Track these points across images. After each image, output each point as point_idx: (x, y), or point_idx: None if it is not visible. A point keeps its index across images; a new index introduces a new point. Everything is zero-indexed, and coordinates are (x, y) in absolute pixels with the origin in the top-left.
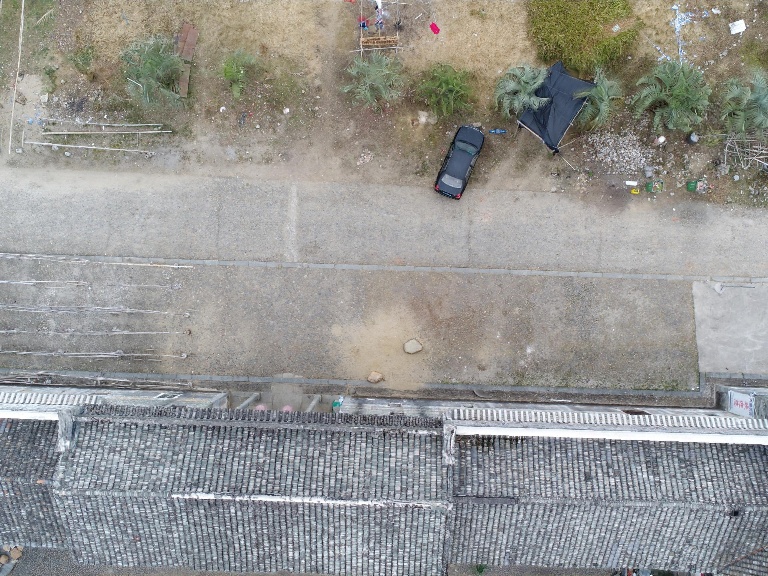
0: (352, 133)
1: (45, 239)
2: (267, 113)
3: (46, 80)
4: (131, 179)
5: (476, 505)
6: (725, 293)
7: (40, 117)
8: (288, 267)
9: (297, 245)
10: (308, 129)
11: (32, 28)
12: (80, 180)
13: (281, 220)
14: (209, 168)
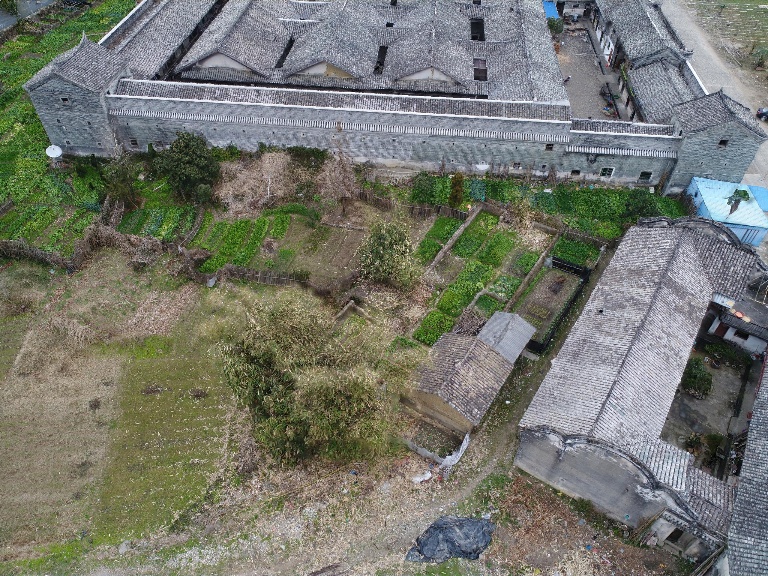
0: (767, 99)
1: (686, 45)
2: (762, 84)
3: (744, 47)
4: (718, 59)
5: (661, 65)
6: (760, 182)
7: (729, 46)
8: (704, 84)
9: (714, 86)
10: (762, 91)
11: (760, 47)
12: (711, 51)
13: (721, 84)
14: (732, 72)
